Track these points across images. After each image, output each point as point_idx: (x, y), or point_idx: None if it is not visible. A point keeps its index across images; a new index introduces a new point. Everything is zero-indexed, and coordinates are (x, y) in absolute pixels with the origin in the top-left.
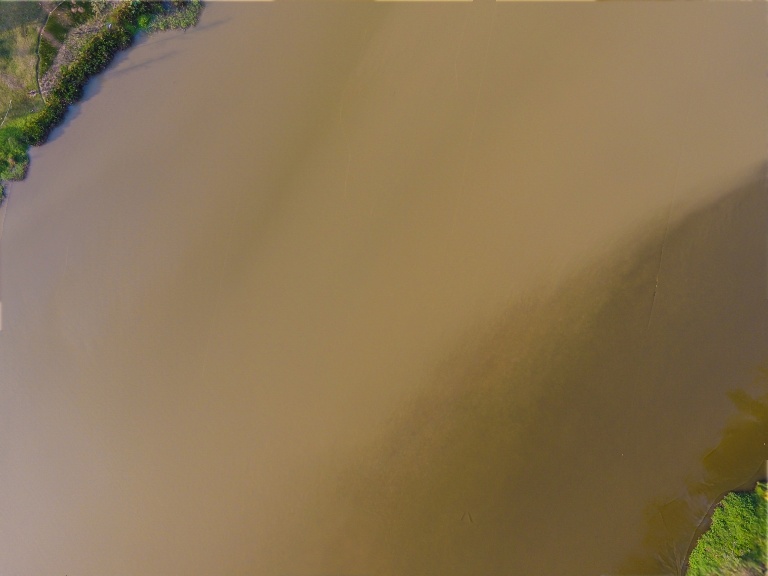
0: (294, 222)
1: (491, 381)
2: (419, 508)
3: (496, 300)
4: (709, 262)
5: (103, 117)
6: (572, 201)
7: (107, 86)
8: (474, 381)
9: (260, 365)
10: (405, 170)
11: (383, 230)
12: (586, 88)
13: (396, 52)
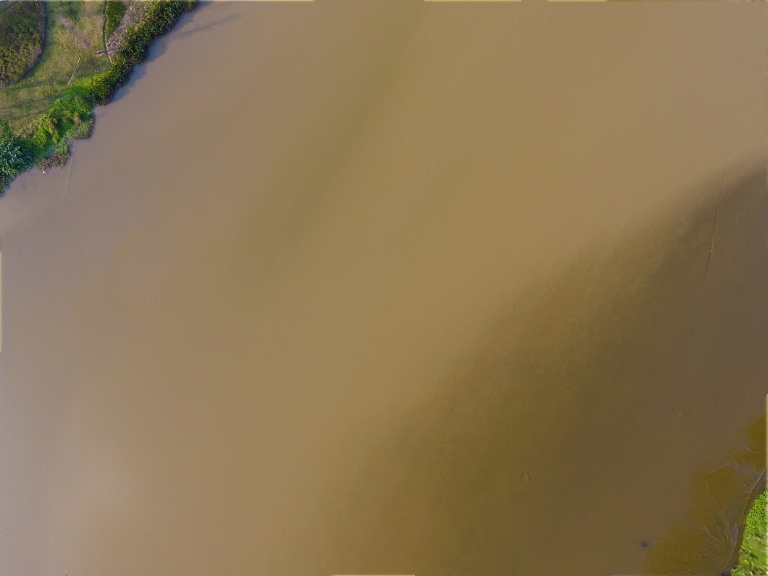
0: (355, 182)
1: (549, 340)
2: (478, 466)
3: (554, 260)
4: (763, 225)
5: (168, 77)
6: (629, 163)
7: (172, 47)
8: (532, 340)
9: (321, 323)
10: (464, 132)
11: (443, 190)
12: (642, 53)
13: (456, 16)
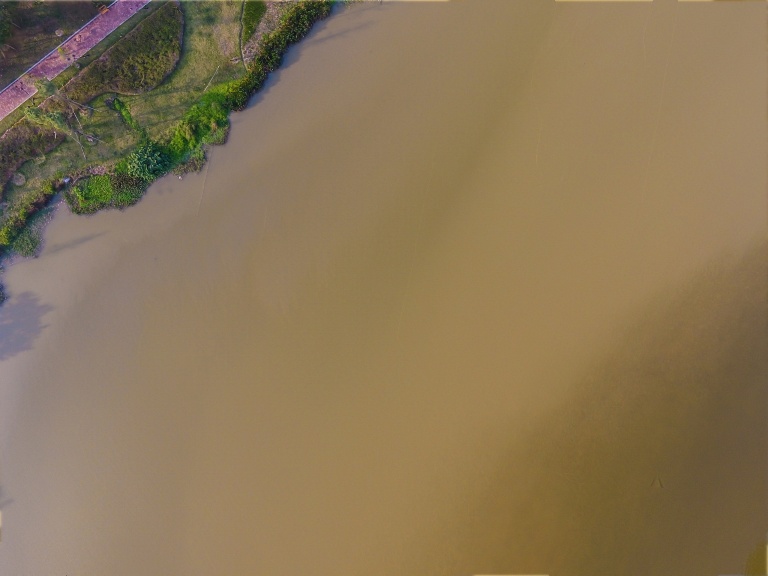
0: (487, 188)
1: (680, 347)
2: (610, 472)
3: (685, 267)
4: None
5: (301, 84)
6: (758, 171)
7: (306, 54)
8: (663, 347)
9: (454, 328)
10: (595, 139)
11: (574, 197)
12: None
13: (586, 25)
